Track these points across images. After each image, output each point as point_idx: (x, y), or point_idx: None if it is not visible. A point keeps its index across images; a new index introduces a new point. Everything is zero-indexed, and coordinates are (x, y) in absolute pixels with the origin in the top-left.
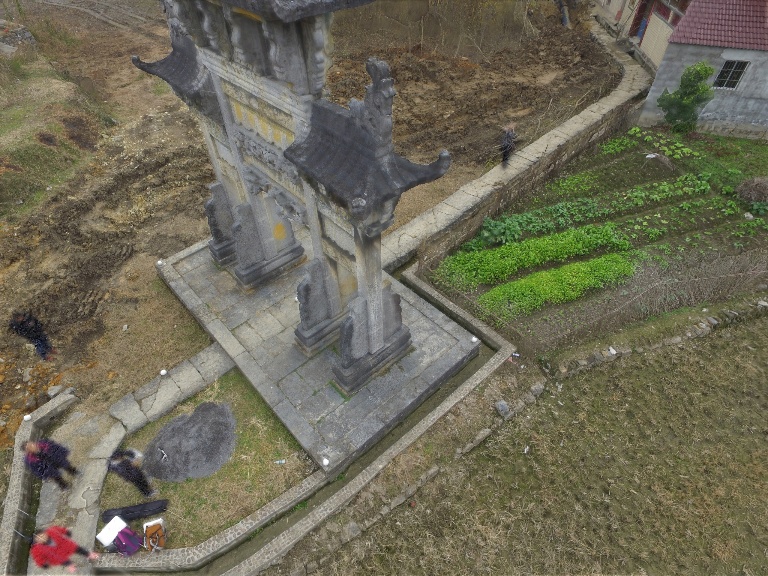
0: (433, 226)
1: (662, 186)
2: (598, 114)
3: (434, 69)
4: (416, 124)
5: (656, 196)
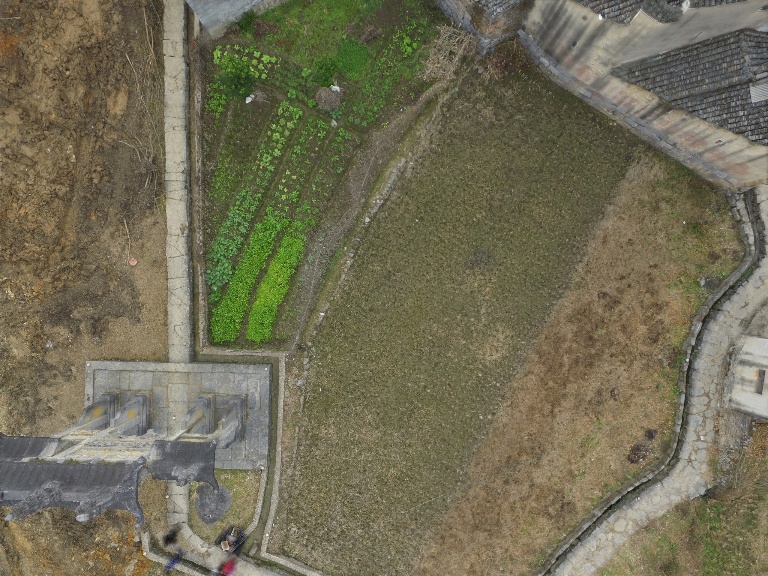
0: (183, 306)
1: (274, 137)
2: (178, 59)
3: None
4: (64, 194)
5: (277, 152)
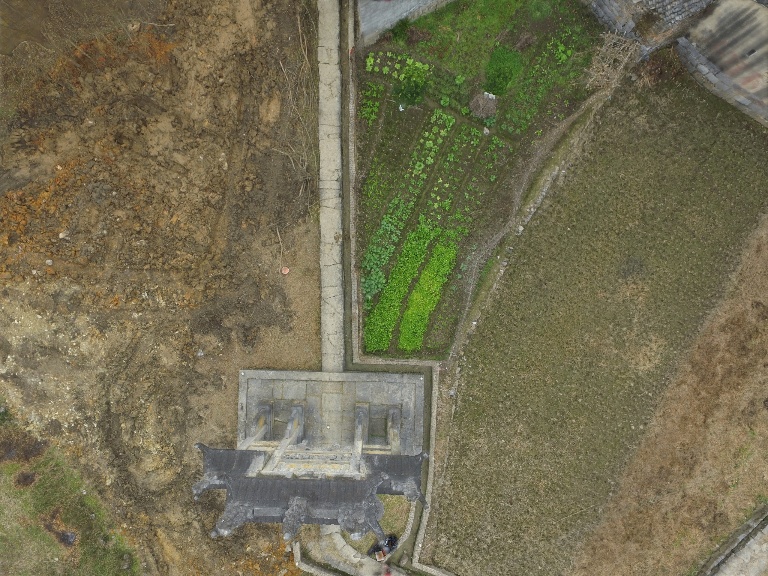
0: (337, 315)
1: (428, 145)
2: (333, 66)
3: (142, 92)
4: (217, 202)
5: (430, 160)
